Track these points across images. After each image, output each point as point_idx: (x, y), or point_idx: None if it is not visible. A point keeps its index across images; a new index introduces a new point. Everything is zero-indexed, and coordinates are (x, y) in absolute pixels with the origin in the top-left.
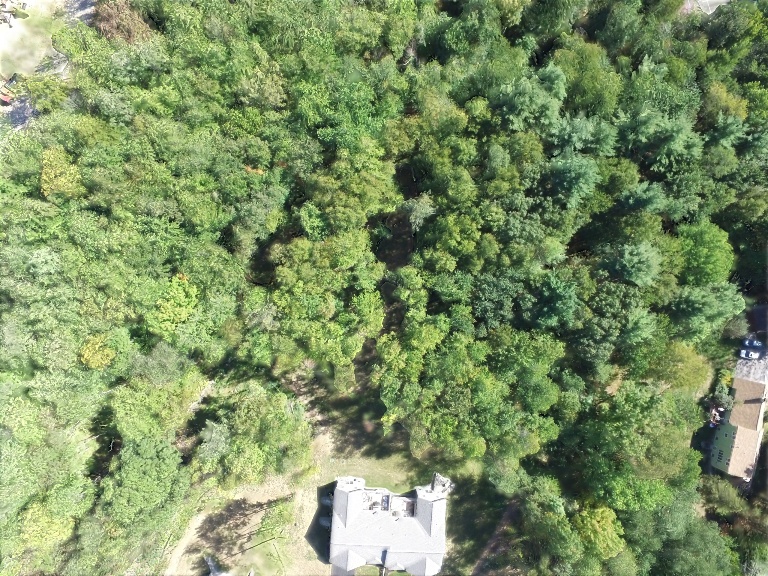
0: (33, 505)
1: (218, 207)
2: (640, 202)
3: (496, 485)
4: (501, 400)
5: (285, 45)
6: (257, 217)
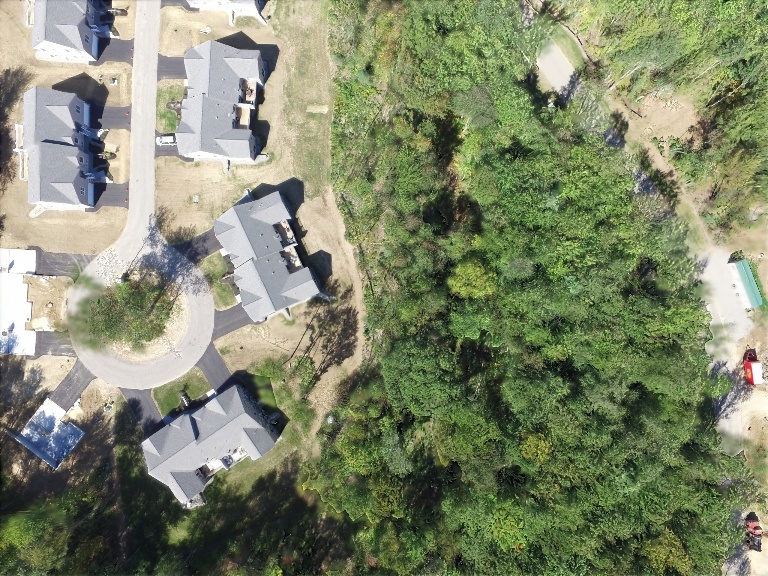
0: None
1: None
2: None
3: None
4: None
5: None
6: None
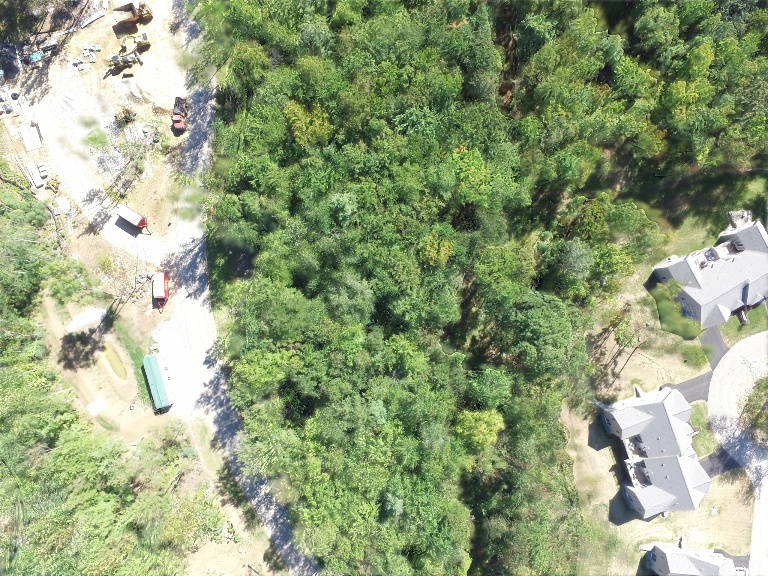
0: (465, 412)
1: (446, 78)
2: None
3: None
4: None
5: None
6: (492, 57)
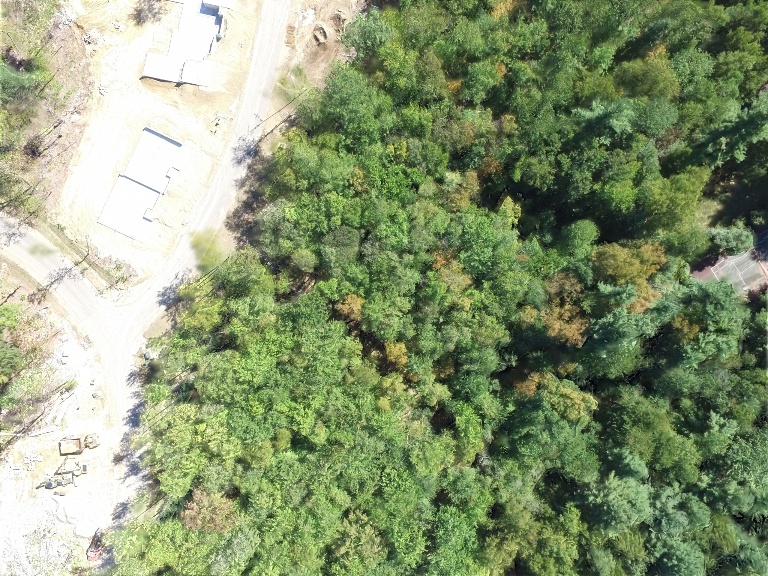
0: None
1: None
2: (748, 571)
3: None
4: None
5: (366, 492)
6: None
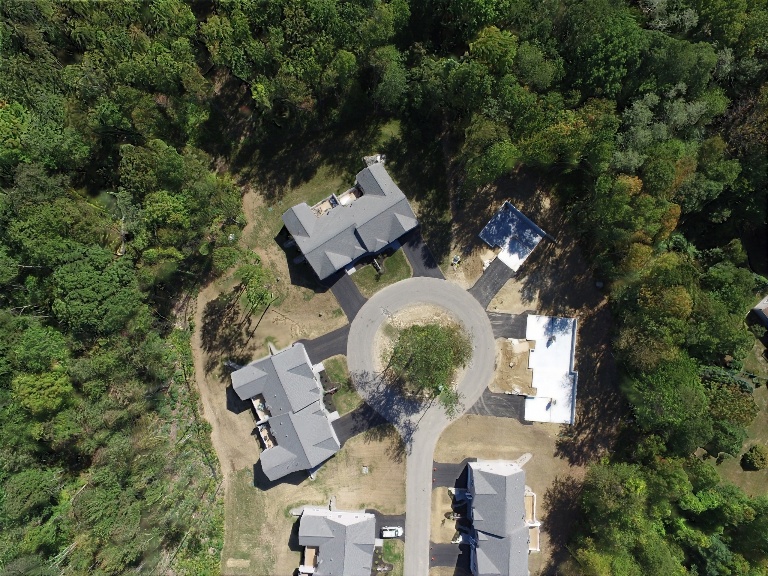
0: (17, 378)
1: None
2: None
3: (390, 87)
4: (335, 3)
5: None
6: (24, 5)
